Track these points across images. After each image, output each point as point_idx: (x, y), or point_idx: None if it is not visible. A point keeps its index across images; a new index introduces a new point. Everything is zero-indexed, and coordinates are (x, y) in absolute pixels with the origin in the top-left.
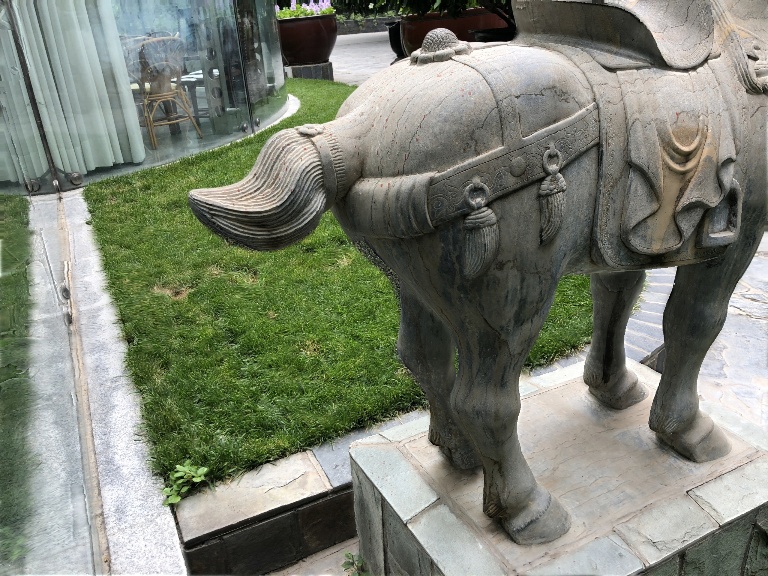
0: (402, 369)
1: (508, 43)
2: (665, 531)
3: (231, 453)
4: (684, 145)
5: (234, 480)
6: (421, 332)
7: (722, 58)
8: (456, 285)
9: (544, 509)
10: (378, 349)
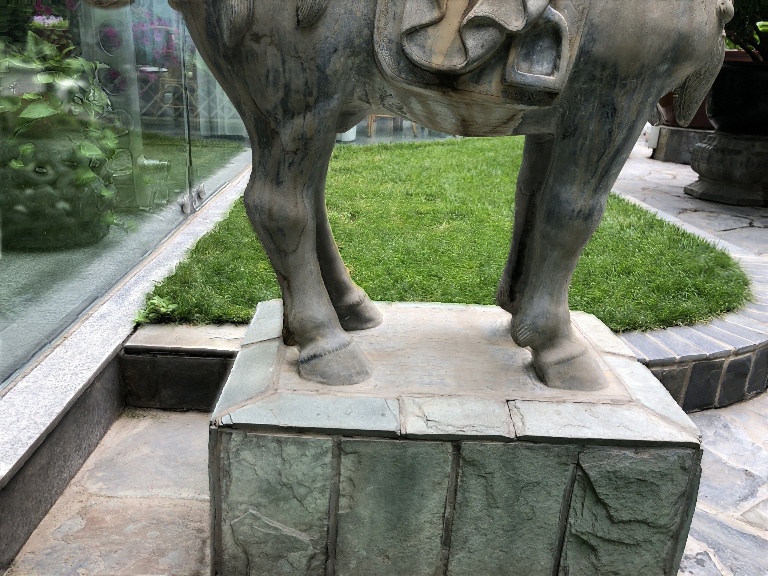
0: (406, 299)
1: None
2: (447, 416)
3: (205, 303)
4: None
5: (198, 325)
6: None
7: None
8: (222, 53)
9: (331, 349)
10: (401, 282)
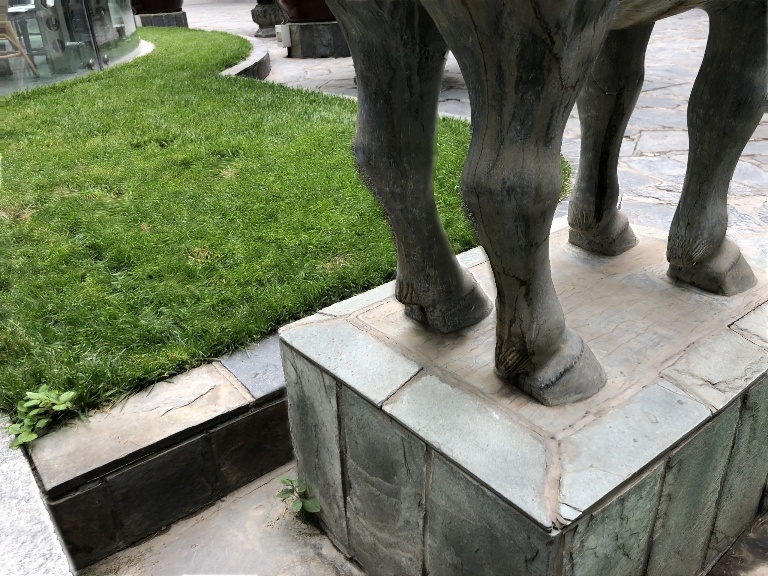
0: None
1: None
2: (722, 370)
3: (107, 371)
4: None
5: (115, 406)
6: (394, 112)
7: None
8: None
9: (579, 353)
10: (287, 248)
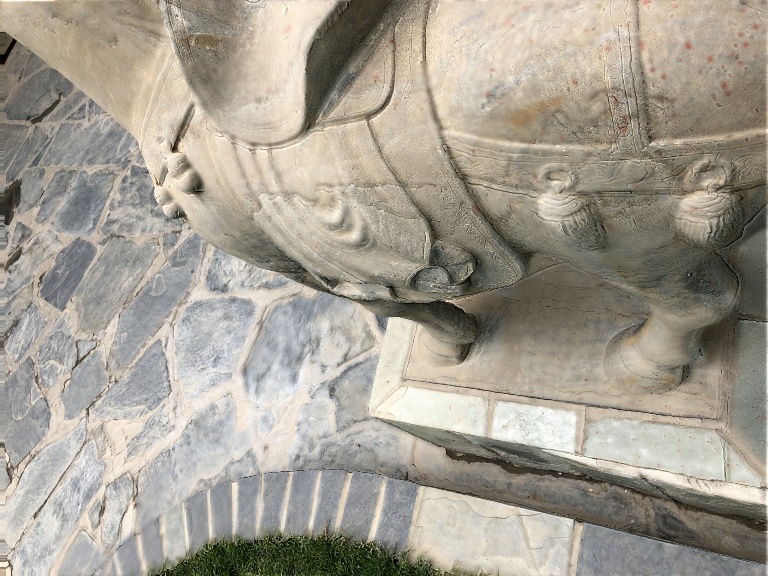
0: None
1: (430, 1)
2: None
3: None
4: None
5: None
6: None
7: None
8: None
9: None
10: None
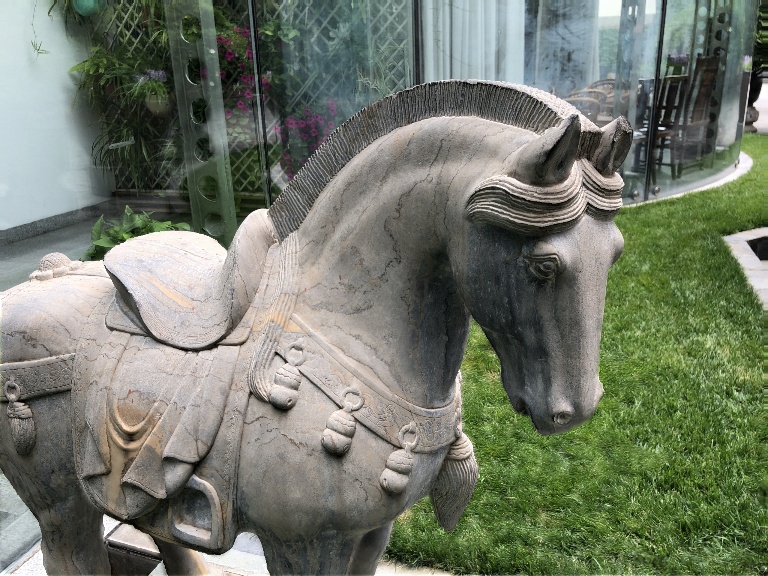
0: None
1: None
2: None
3: None
4: (127, 424)
5: None
6: None
7: (245, 347)
8: None
9: None
10: None
